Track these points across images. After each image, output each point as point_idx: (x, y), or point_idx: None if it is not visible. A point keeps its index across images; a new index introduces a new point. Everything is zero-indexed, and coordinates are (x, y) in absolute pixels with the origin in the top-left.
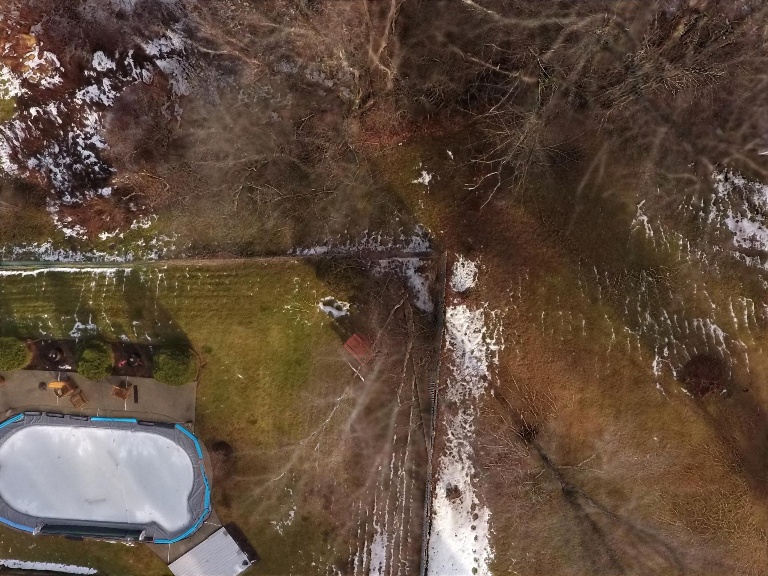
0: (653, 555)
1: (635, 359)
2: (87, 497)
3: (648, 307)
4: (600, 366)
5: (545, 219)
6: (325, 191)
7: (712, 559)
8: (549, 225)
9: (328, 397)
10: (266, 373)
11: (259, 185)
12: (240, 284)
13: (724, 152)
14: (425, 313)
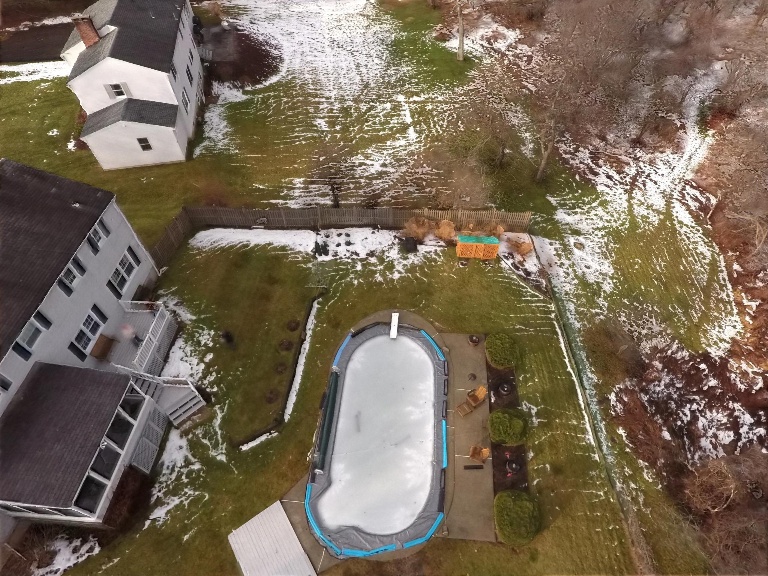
0: None
1: None
2: (363, 414)
3: None
4: None
5: None
6: None
7: None
8: None
9: None
10: None
11: None
12: None
13: None
14: None
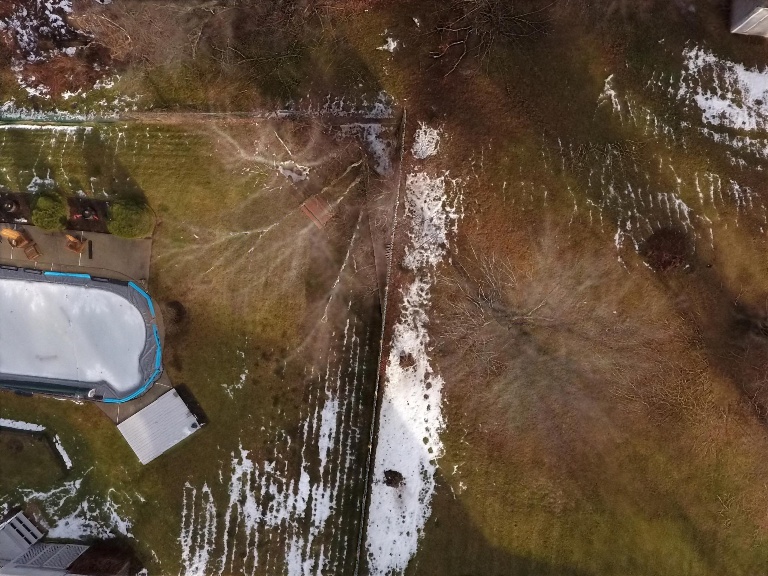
0: (609, 430)
1: (597, 232)
2: (38, 353)
3: (612, 180)
4: (561, 237)
5: (510, 90)
6: (289, 55)
7: (669, 436)
8: (514, 96)
9: (284, 261)
10: (222, 235)
11: (223, 48)
12: (200, 145)
13: (695, 29)
14: (385, 179)
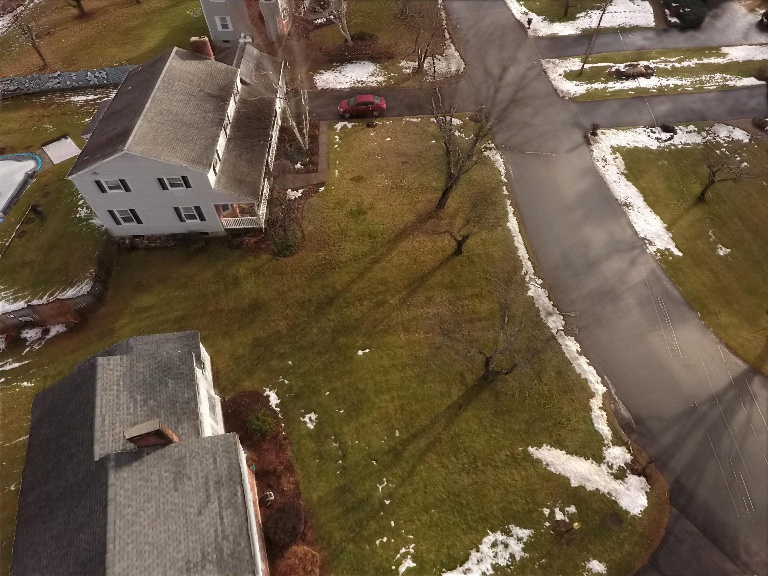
0: None
1: None
2: None
3: (8, 49)
4: None
5: None
6: None
7: None
8: None
9: None
10: None
11: None
12: None
13: None
14: None
